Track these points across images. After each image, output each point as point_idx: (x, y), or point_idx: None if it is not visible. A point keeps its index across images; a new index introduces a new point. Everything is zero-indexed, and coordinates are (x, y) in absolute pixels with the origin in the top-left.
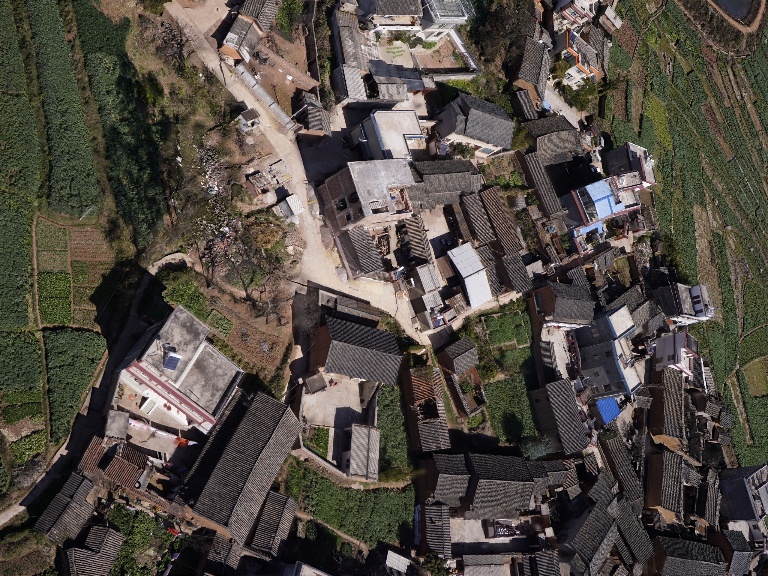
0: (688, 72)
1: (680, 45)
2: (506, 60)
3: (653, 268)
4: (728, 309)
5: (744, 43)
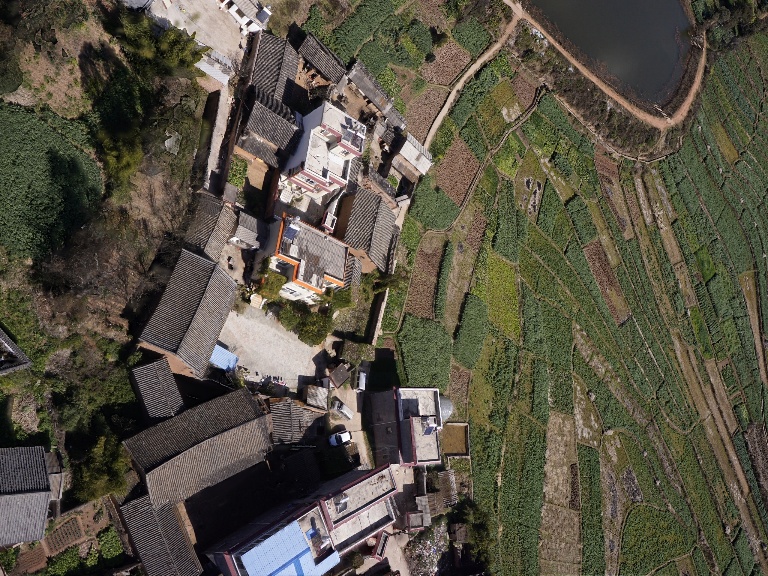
0: (568, 199)
1: (556, 162)
2: (137, 296)
3: (445, 573)
4: (591, 574)
5: (662, 142)
